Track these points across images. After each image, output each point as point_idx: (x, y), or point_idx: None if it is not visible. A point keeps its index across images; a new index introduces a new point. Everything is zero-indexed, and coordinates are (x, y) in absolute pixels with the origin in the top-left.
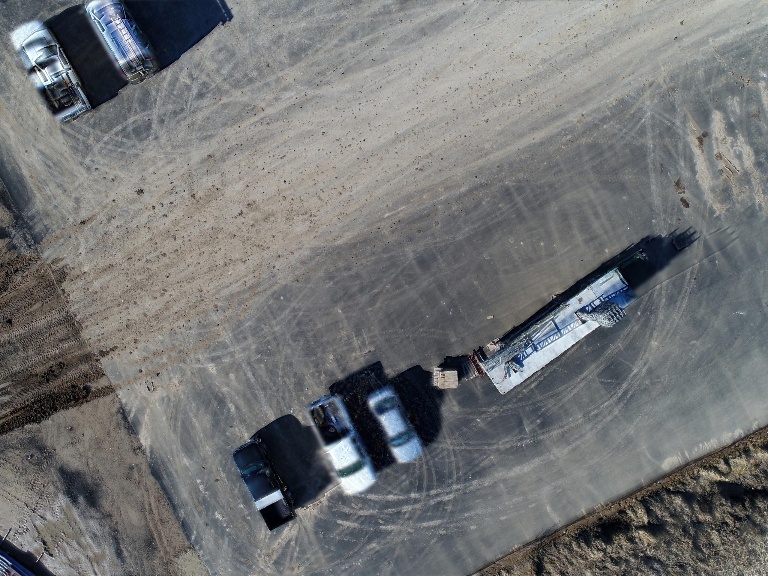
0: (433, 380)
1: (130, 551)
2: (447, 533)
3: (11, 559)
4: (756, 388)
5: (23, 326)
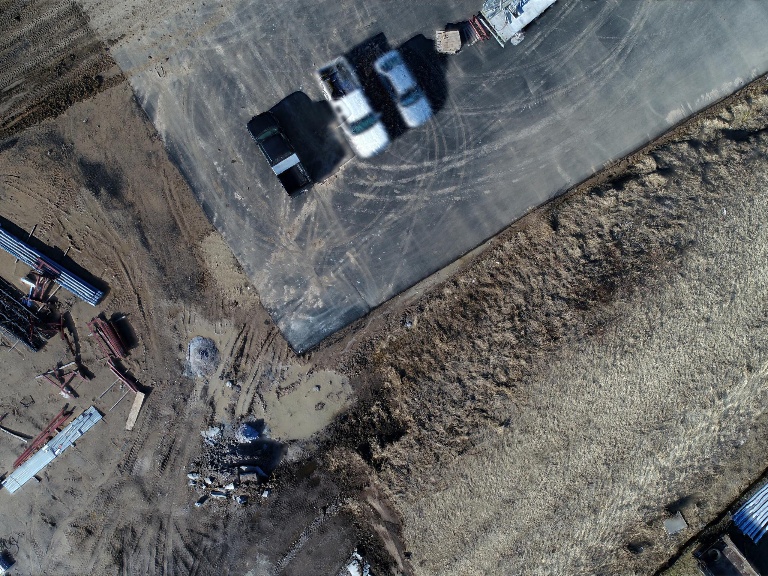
0: (436, 48)
1: (154, 239)
2: (462, 199)
3: (39, 253)
4: (752, 36)
5: (31, 22)
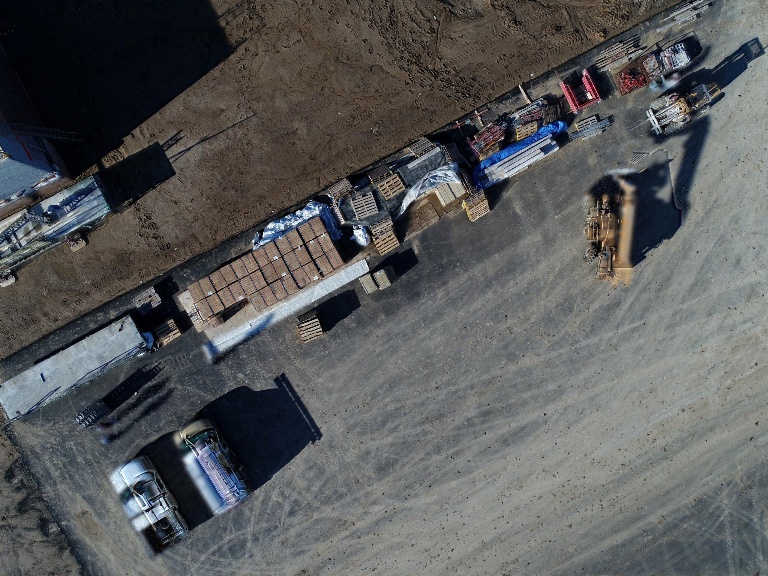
0: None
1: None
2: None
3: None
4: None
5: None
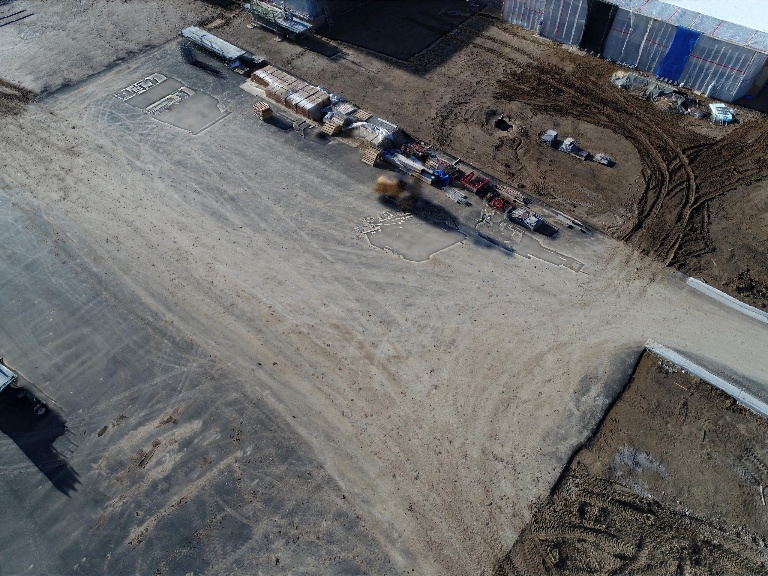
0: None
1: None
2: None
3: None
4: None
5: None
